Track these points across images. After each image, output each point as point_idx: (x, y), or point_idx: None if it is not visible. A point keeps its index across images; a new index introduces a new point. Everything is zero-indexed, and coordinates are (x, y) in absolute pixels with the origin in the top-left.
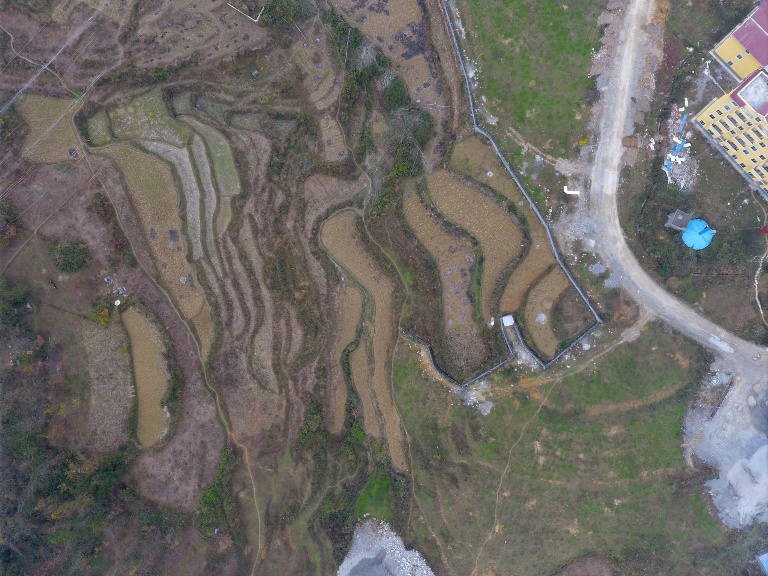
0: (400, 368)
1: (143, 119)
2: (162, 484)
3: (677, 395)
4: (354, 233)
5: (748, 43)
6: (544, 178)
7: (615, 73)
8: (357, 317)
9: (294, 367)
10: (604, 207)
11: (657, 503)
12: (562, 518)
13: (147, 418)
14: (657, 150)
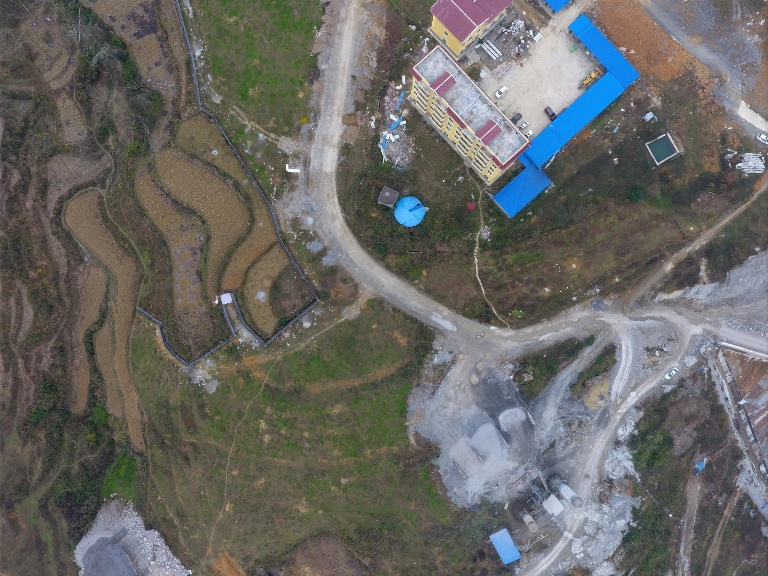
0: (137, 347)
1: None
2: None
3: (399, 373)
4: (98, 213)
5: (445, 19)
6: (268, 156)
7: (335, 51)
8: (100, 297)
9: (24, 346)
10: (323, 185)
11: (385, 482)
12: (291, 497)
13: None
14: (376, 128)
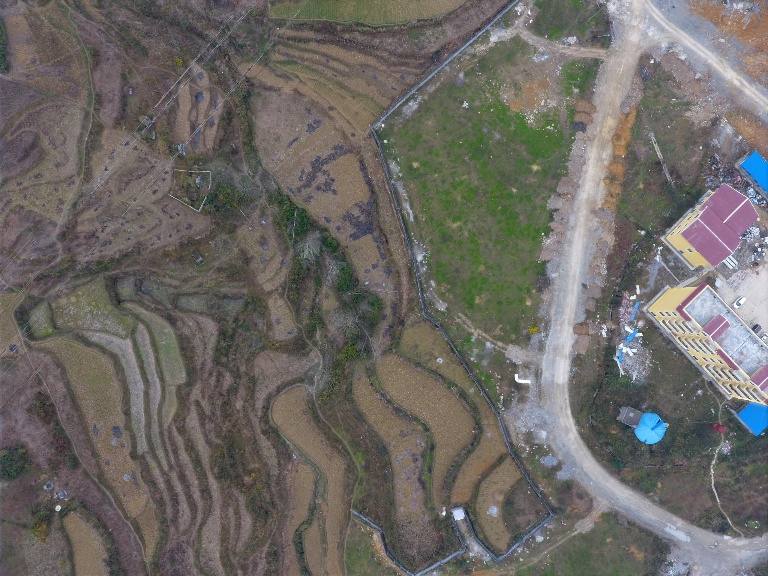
0: (353, 551)
1: (86, 309)
2: None
3: None
4: (305, 409)
5: (697, 243)
6: (495, 364)
7: (565, 259)
8: (309, 495)
9: (243, 556)
10: (555, 397)
11: None
12: None
13: None
14: (609, 338)
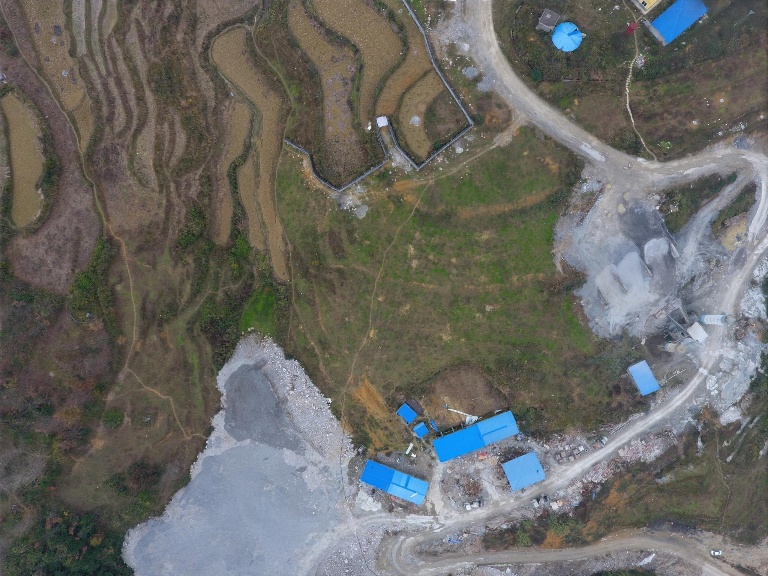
0: (283, 179)
1: None
2: (36, 266)
3: (548, 201)
4: (244, 50)
5: None
6: None
7: None
8: (245, 132)
9: (176, 170)
10: (479, 13)
11: (528, 311)
12: (435, 324)
13: (22, 200)
14: None
